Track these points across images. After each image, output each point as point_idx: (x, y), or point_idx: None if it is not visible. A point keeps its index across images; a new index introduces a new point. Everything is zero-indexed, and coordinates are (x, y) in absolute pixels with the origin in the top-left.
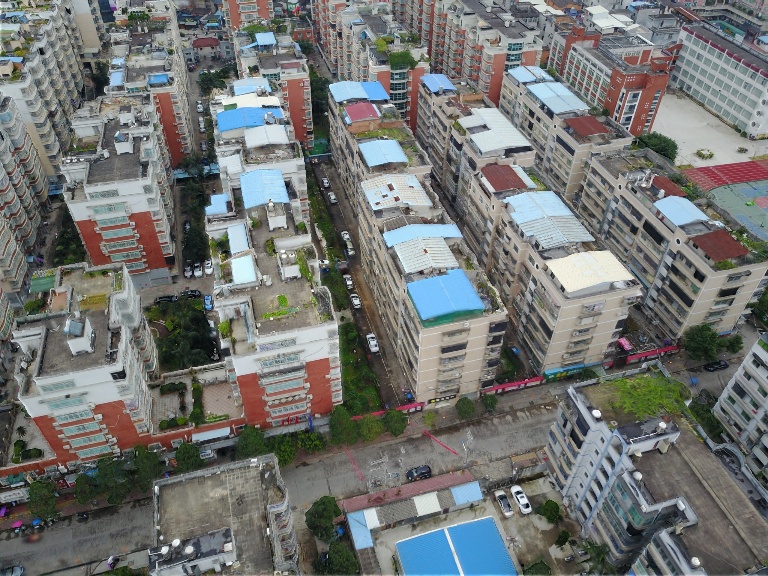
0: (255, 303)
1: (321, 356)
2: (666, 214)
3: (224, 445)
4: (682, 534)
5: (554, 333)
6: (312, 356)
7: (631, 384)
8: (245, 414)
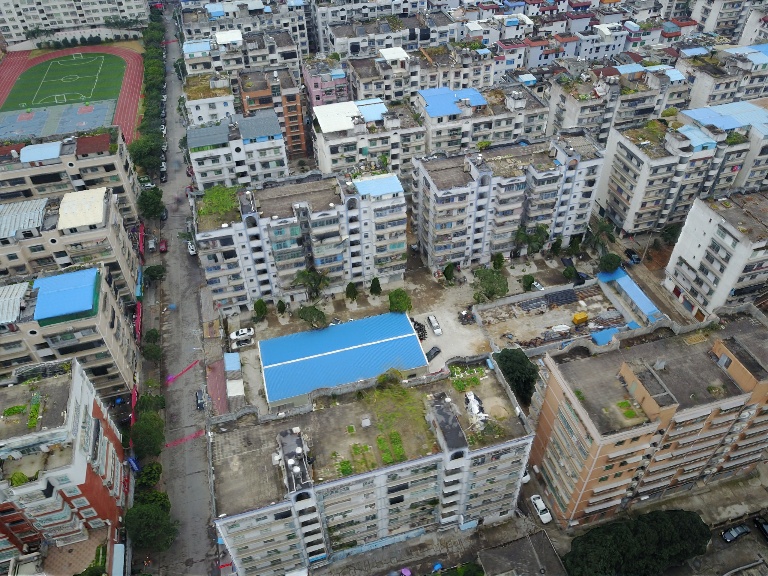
0: None
1: (91, 402)
2: (40, 158)
3: (130, 560)
4: (313, 211)
5: (119, 261)
6: (89, 407)
7: (208, 205)
8: (109, 519)
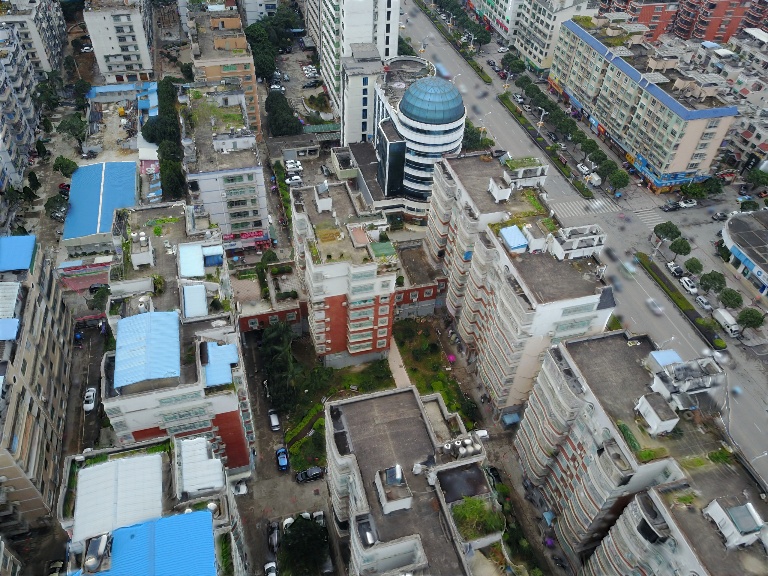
0: (184, 231)
1: None
2: None
3: None
4: None
5: None
6: None
7: None
8: None
